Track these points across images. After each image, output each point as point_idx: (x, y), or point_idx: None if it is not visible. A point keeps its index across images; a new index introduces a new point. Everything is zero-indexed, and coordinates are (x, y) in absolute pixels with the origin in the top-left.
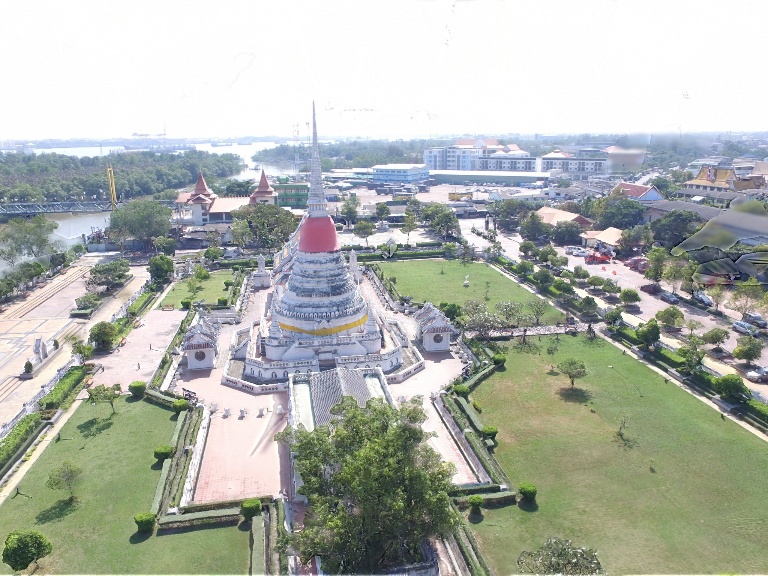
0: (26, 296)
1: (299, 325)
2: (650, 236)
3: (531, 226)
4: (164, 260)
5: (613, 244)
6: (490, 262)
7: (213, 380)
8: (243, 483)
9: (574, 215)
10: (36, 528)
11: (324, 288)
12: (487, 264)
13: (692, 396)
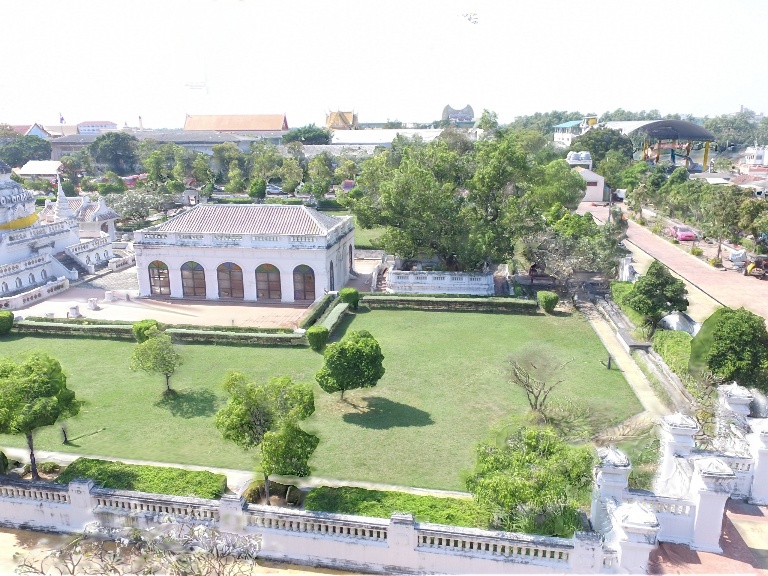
0: None
1: None
2: (89, 161)
3: None
4: None
5: None
6: None
7: None
8: (256, 321)
9: None
10: None
11: None
12: None
13: (337, 212)
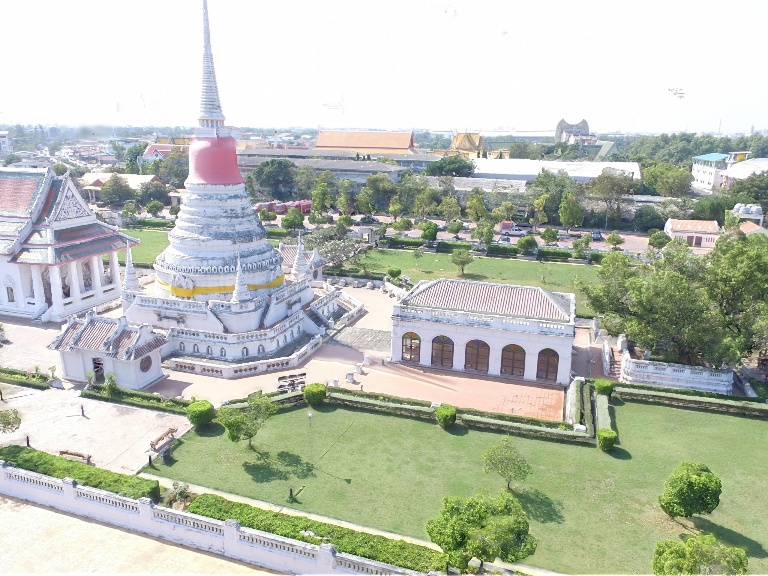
0: None
1: (250, 280)
2: (253, 185)
3: (120, 189)
4: None
5: None
6: (134, 227)
7: (209, 382)
8: (514, 402)
9: (148, 176)
10: (573, 522)
11: (257, 228)
12: (134, 229)
13: None
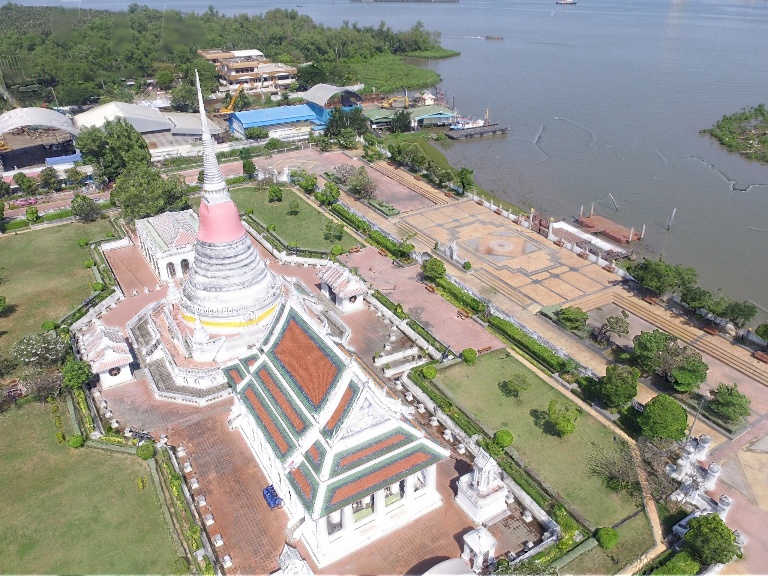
0: (704, 329)
1: None
2: None
3: None
4: None
5: None
6: None
7: (309, 282)
8: None
9: None
10: None
11: None
12: None
13: None
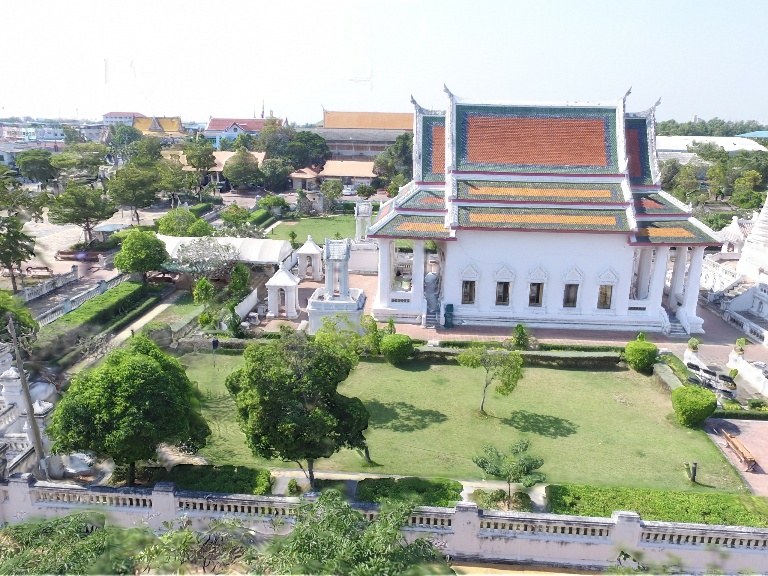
0: None
1: None
2: None
3: (254, 168)
4: (173, 366)
5: (375, 175)
6: (343, 212)
7: None
8: None
9: (256, 153)
10: None
11: None
12: (349, 215)
13: None
